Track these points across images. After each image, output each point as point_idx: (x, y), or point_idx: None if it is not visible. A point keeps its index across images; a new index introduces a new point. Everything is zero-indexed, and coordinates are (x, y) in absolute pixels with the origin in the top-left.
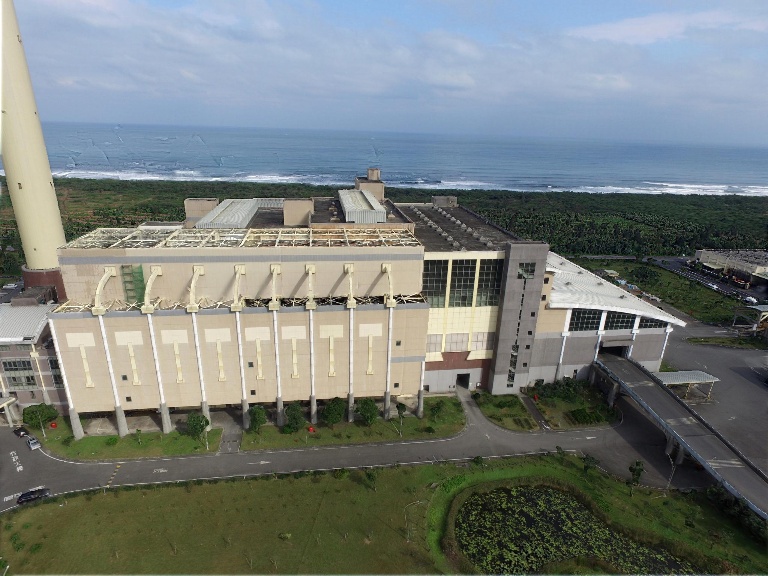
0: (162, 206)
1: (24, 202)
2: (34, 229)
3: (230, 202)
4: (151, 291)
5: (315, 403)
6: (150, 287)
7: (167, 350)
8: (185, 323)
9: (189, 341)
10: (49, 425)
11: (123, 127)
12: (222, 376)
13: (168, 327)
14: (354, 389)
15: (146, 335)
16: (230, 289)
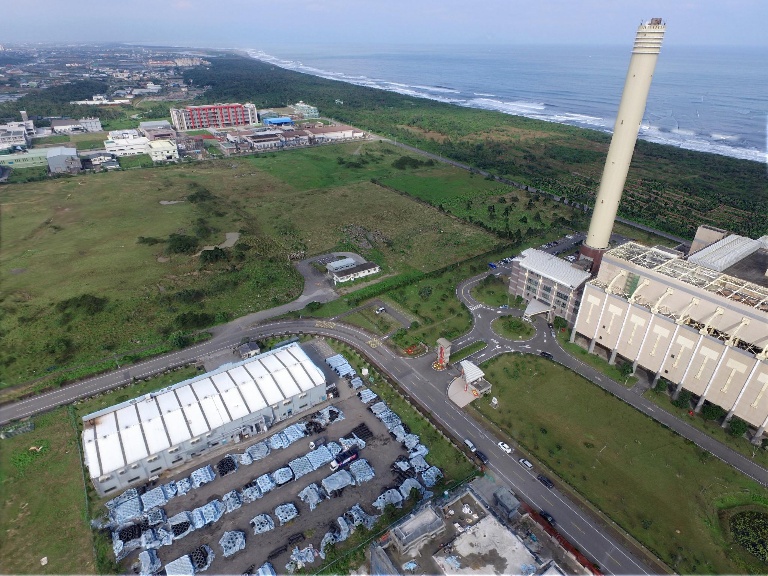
0: (702, 188)
1: (600, 210)
2: (598, 225)
3: (734, 239)
4: (639, 291)
5: (703, 401)
6: (638, 290)
7: (631, 325)
8: (647, 316)
9: (644, 326)
10: (562, 329)
11: (709, 96)
12: (653, 353)
13: (637, 314)
14: (736, 409)
15: (624, 312)
16: (684, 309)
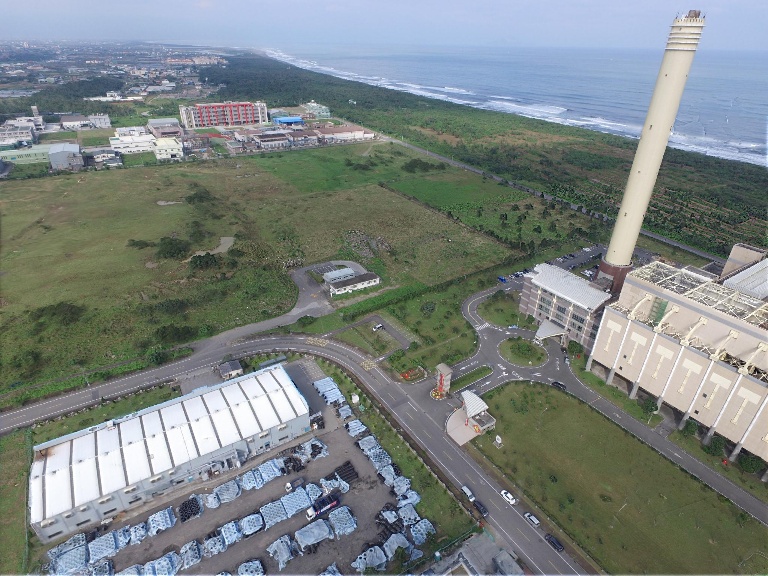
0: (731, 198)
1: (623, 224)
2: (620, 240)
3: None
4: None
5: (740, 449)
6: (666, 318)
7: (656, 356)
8: (675, 348)
9: (672, 359)
10: (577, 355)
11: (739, 101)
12: (681, 390)
13: (664, 345)
14: None
15: (649, 342)
16: (719, 342)
